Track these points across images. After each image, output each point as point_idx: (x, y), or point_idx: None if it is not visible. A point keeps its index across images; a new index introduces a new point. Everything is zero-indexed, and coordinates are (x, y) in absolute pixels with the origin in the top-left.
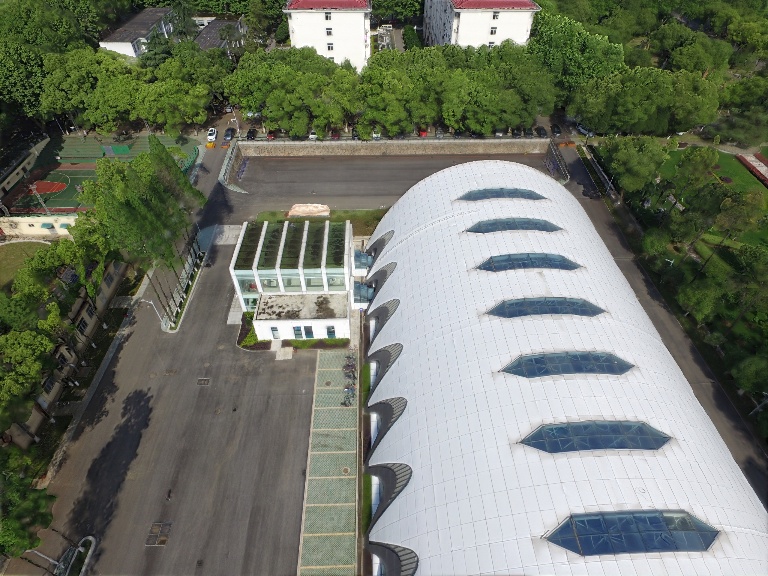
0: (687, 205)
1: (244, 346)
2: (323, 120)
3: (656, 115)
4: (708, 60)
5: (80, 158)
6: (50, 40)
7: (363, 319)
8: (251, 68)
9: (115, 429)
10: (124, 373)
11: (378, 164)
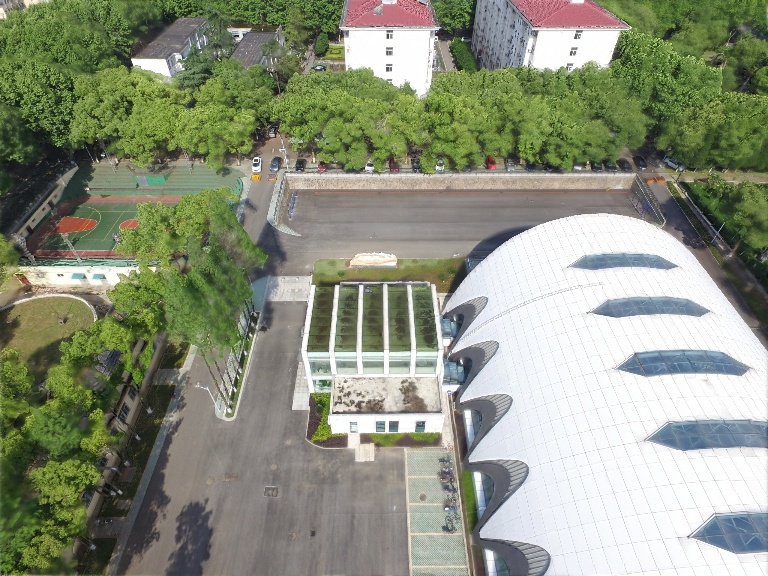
0: None
1: (316, 441)
2: (385, 153)
3: (760, 149)
4: None
5: (111, 190)
6: (80, 58)
7: (453, 406)
8: (303, 92)
9: (169, 560)
10: (175, 477)
11: (443, 201)
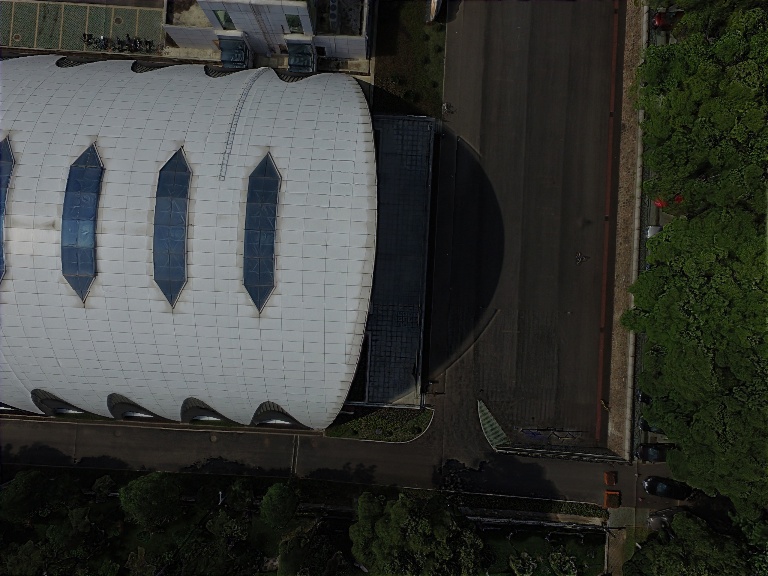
0: None
1: None
2: None
3: None
4: None
5: None
6: None
7: None
8: None
9: None
10: None
11: (587, 113)
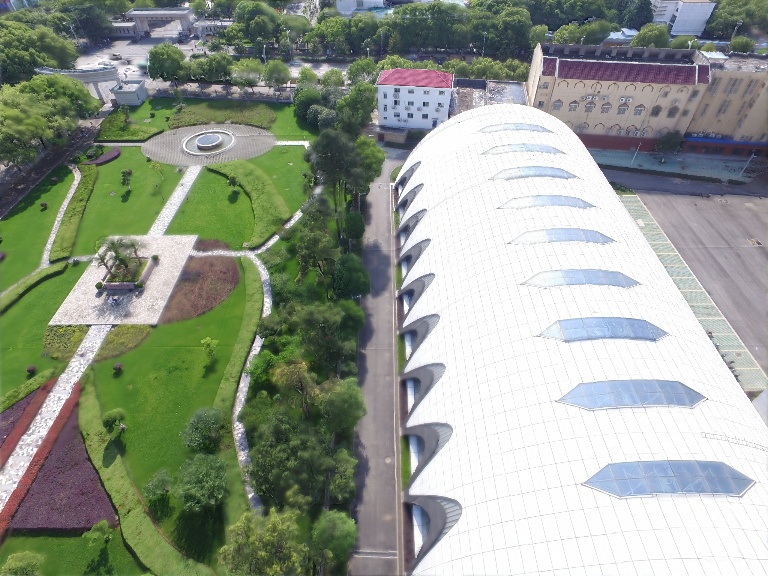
0: None
1: None
2: None
3: None
4: None
5: None
6: None
7: None
8: None
9: None
10: None
11: None
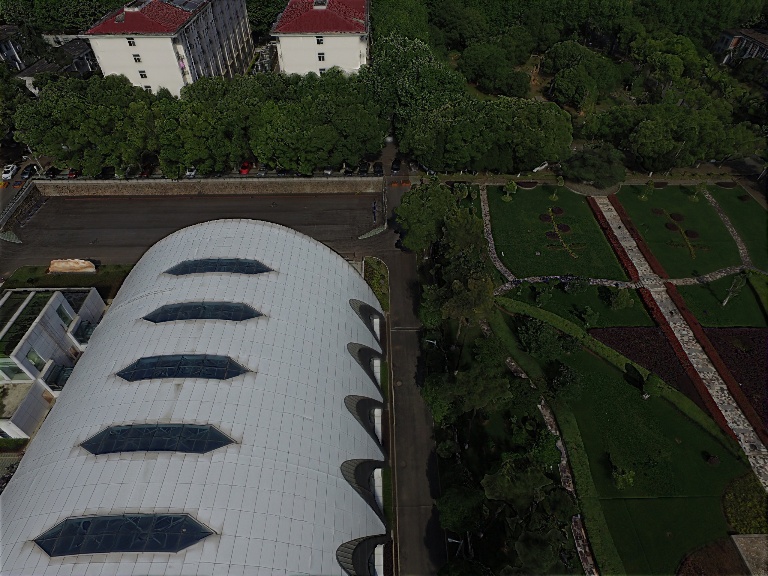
0: (506, 260)
1: None
2: (114, 159)
3: (497, 152)
4: (590, 84)
5: None
6: None
7: None
8: None
9: None
10: None
11: (187, 206)
